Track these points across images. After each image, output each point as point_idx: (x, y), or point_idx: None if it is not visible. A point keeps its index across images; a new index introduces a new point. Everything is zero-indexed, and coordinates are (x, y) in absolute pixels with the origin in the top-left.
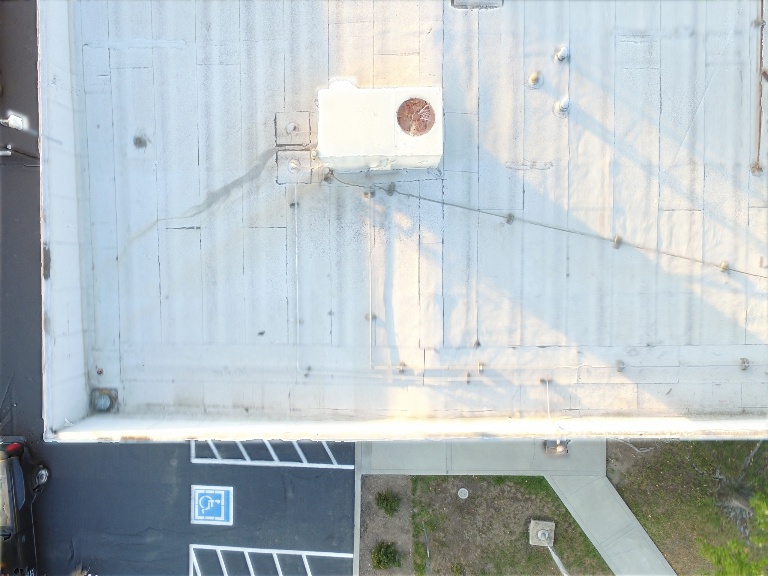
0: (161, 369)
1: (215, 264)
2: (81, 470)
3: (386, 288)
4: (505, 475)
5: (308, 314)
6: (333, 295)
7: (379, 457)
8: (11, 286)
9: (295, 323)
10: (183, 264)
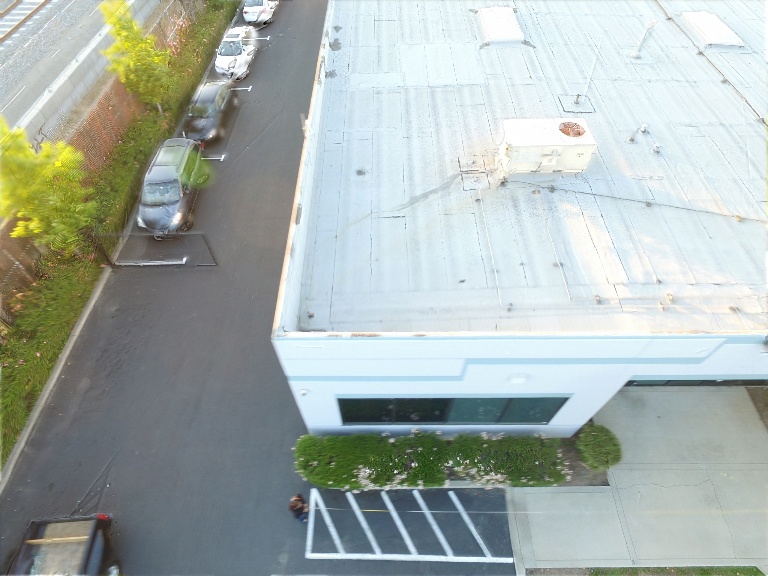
0: (370, 312)
1: (418, 237)
2: (162, 574)
3: (565, 245)
4: (707, 566)
5: (502, 266)
6: (521, 252)
7: (542, 544)
8: (149, 361)
9: (492, 272)
10: (391, 239)
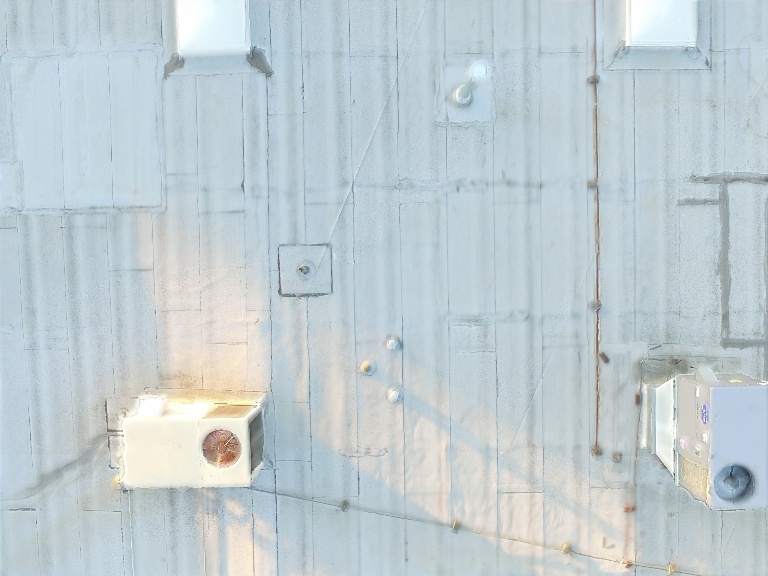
0: None
1: (52, 546)
2: None
3: (222, 575)
4: None
5: None
6: None
7: None
8: None
9: None
10: (20, 545)
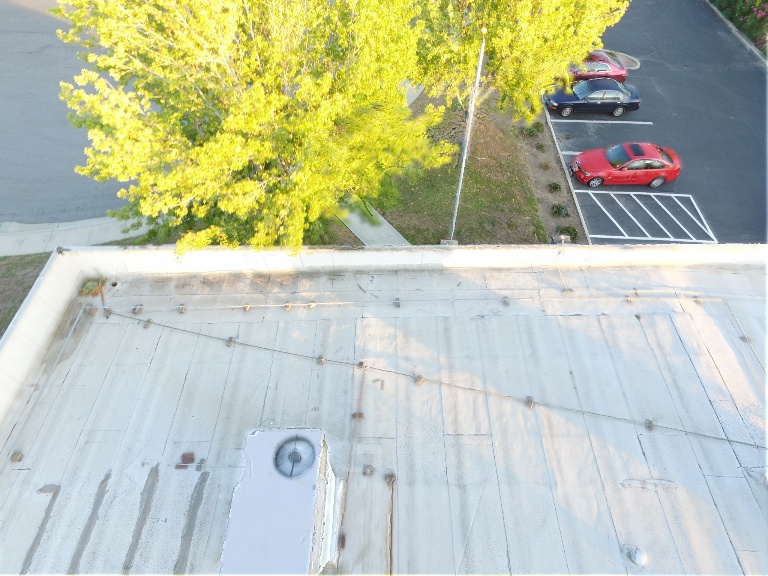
0: None
1: None
2: None
3: (744, 362)
4: None
5: None
6: None
7: None
8: None
9: None
10: None
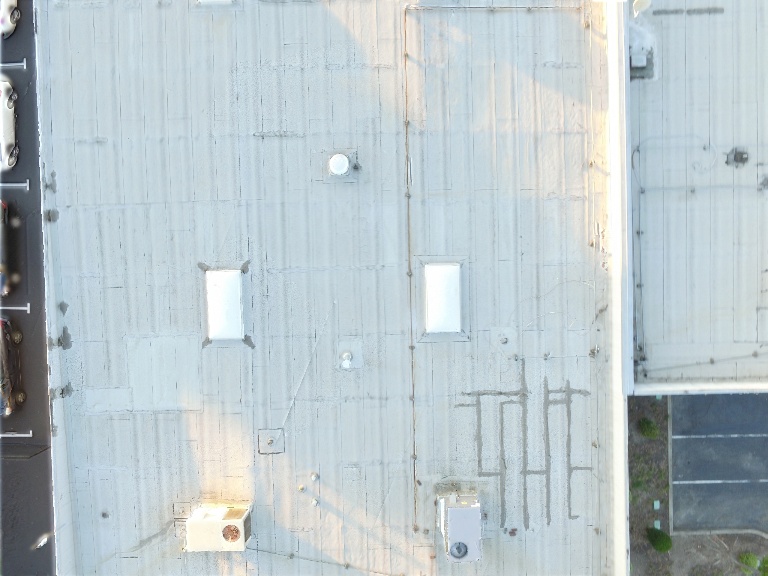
0: None
1: (145, 575)
2: None
3: None
4: None
5: None
6: None
7: None
8: (35, 518)
9: None
10: (129, 575)
